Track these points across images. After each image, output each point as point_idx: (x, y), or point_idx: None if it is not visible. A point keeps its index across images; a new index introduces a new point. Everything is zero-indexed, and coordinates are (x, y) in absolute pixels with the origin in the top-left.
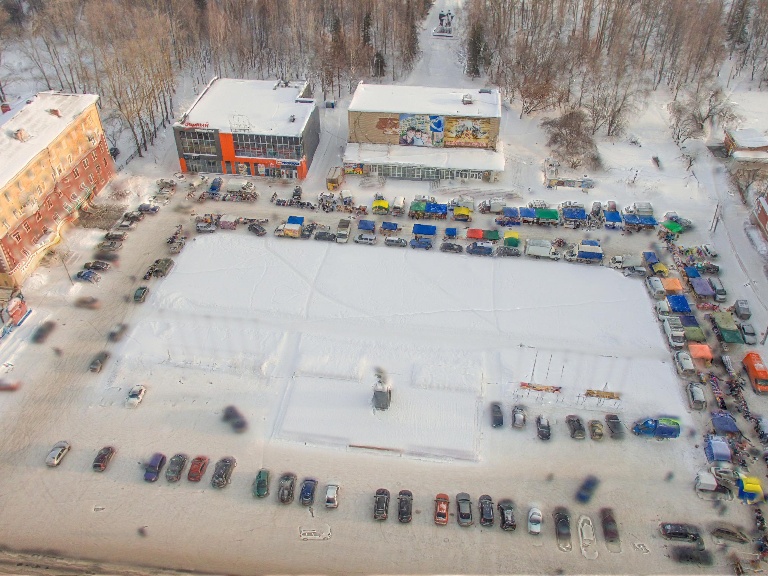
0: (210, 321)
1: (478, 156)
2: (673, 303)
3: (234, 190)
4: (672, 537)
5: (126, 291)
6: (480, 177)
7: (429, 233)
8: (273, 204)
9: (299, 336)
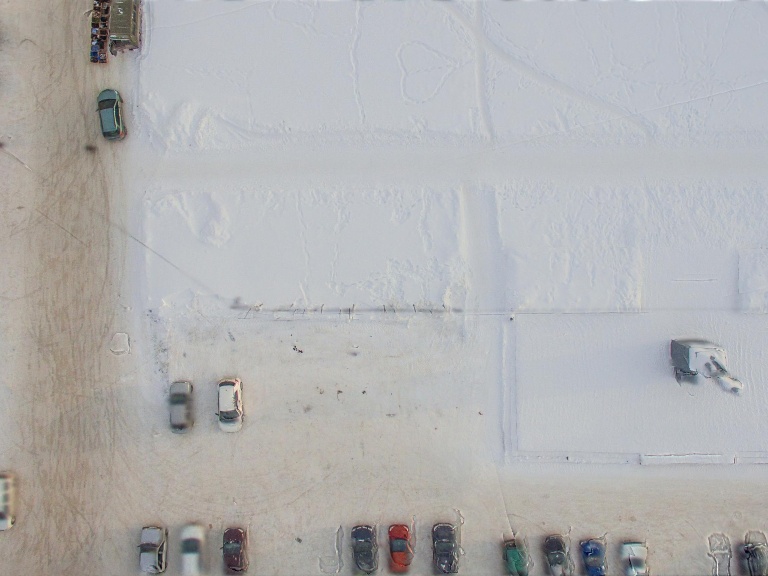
0: (291, 174)
1: None
2: None
3: None
4: None
5: (71, 104)
6: None
7: None
8: None
9: (491, 199)
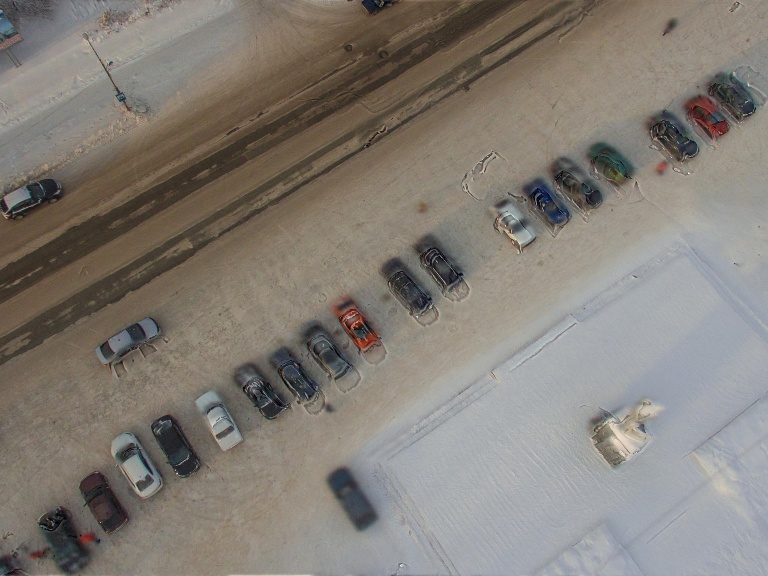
0: None
1: None
2: None
3: None
4: (6, 575)
5: None
6: None
7: None
8: None
9: None
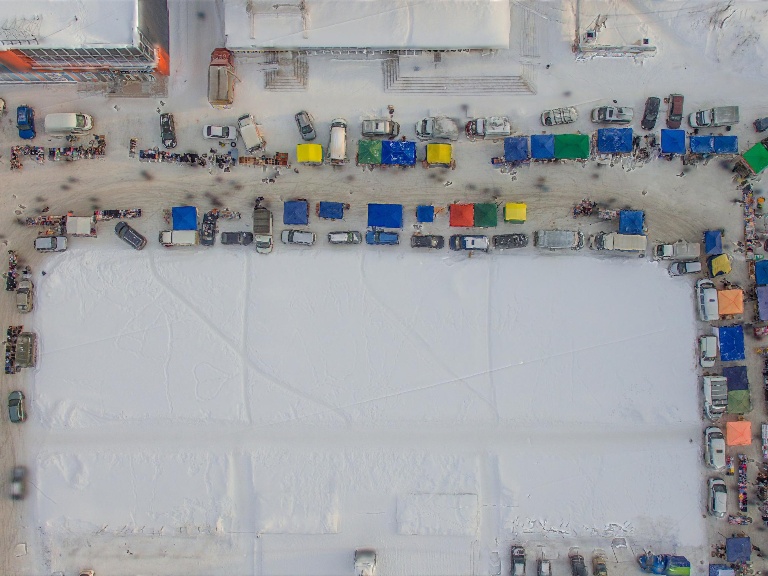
0: (127, 443)
1: (463, 12)
2: (725, 346)
3: (60, 135)
4: None
5: None
6: (466, 50)
7: (393, 225)
8: (135, 160)
9: (248, 461)
